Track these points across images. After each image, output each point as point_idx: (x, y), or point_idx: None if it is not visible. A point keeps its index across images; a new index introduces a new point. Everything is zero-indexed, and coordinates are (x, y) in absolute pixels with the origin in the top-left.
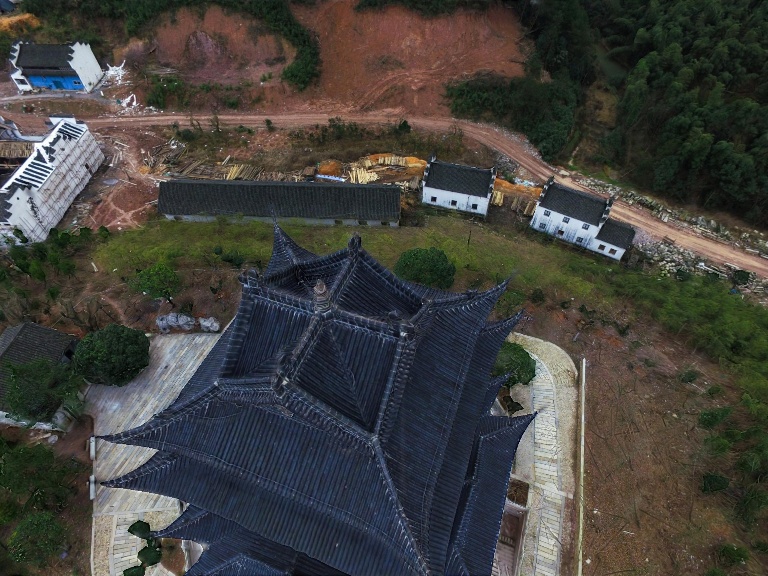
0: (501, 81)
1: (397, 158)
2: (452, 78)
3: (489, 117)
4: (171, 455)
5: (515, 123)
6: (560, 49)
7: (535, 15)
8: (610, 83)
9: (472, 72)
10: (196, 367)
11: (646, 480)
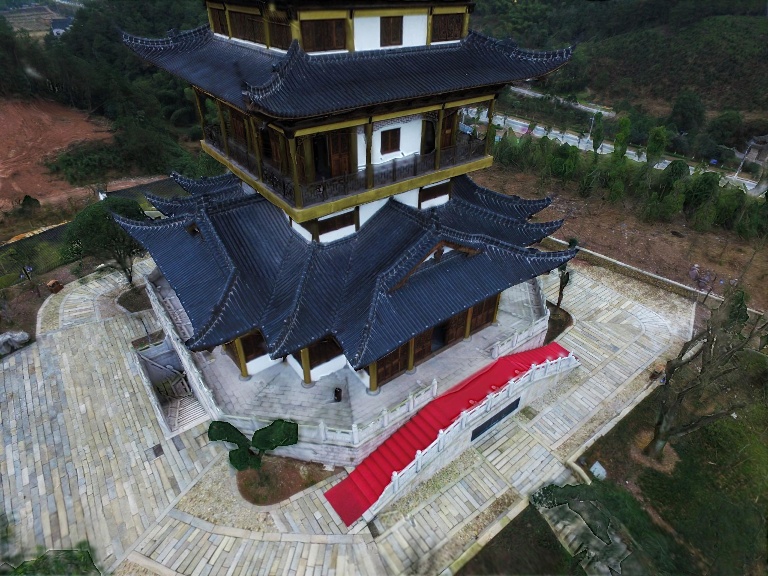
0: (102, 143)
1: (49, 227)
2: (45, 155)
3: (115, 175)
4: (279, 63)
5: (146, 169)
6: (135, 111)
7: (86, 97)
8: (192, 133)
9: (63, 146)
10: (42, 380)
11: (484, 183)
